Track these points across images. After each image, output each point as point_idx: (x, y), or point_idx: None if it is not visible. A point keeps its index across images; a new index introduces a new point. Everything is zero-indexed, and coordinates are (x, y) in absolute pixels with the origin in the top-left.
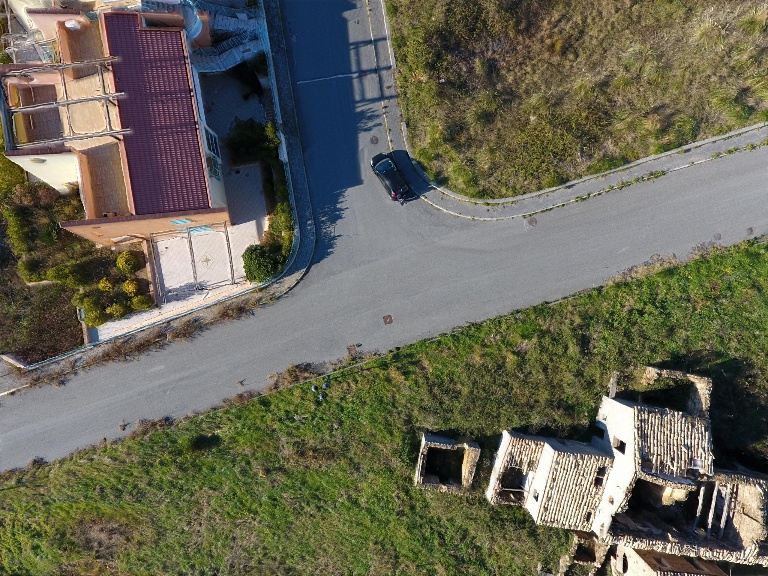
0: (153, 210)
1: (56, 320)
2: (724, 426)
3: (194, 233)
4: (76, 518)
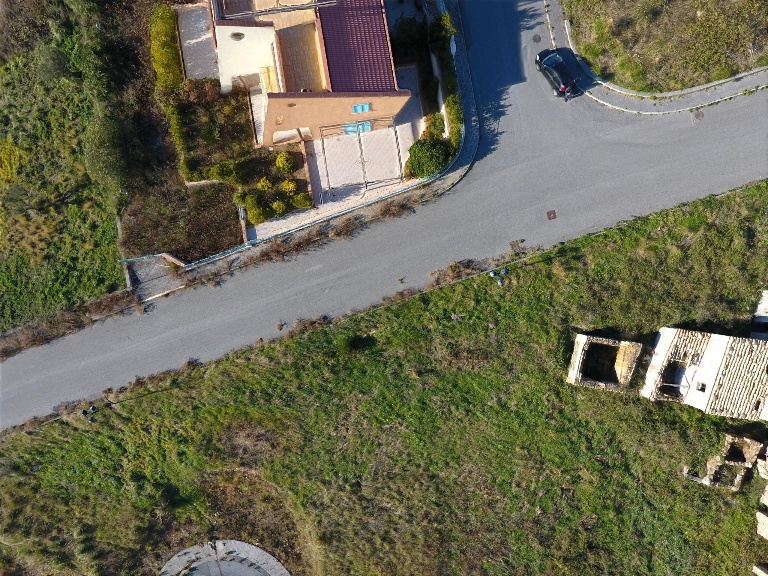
0: (347, 89)
1: (216, 219)
2: None
3: (350, 135)
4: (224, 423)
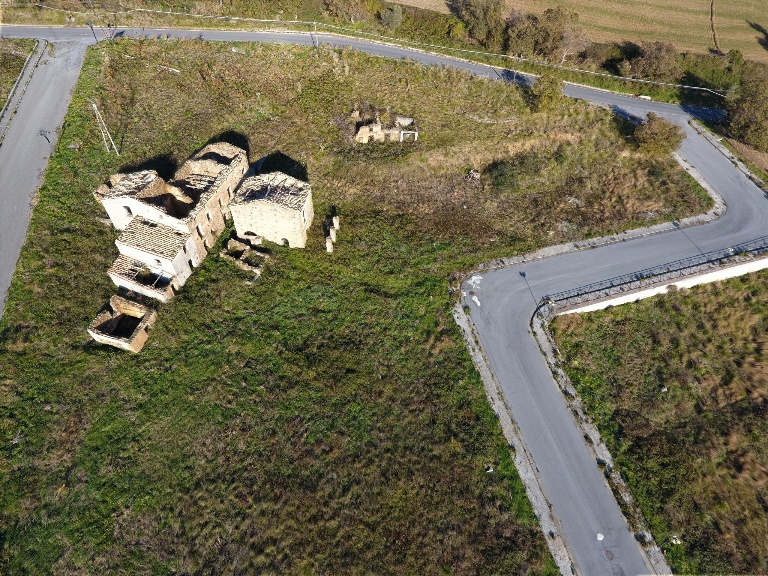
0: None
1: None
2: None
3: None
4: None
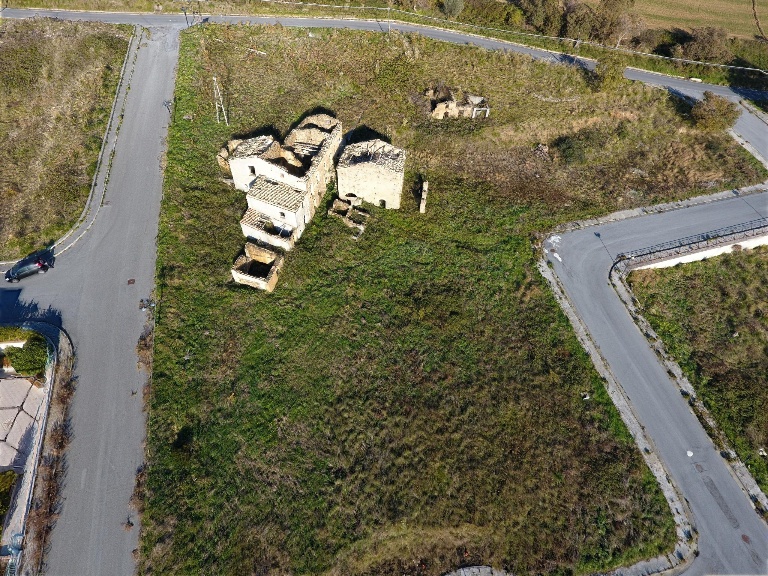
0: None
1: None
2: None
3: None
4: None
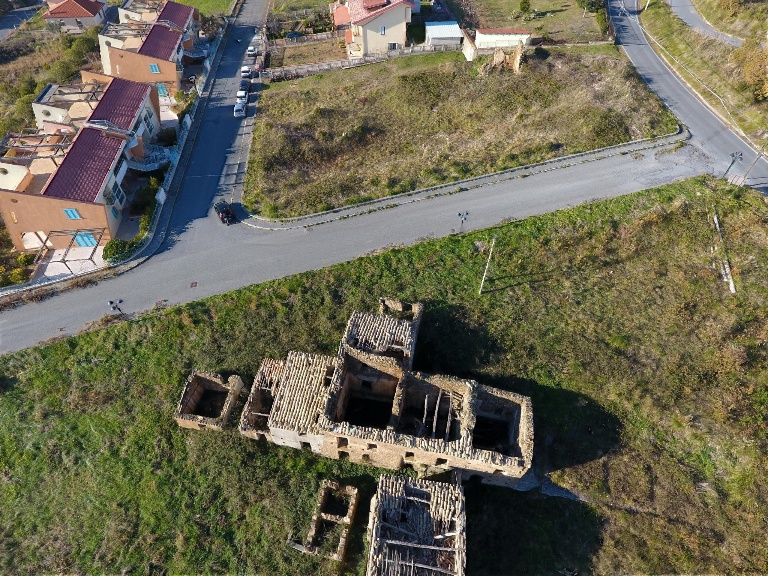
0: (55, 195)
1: None
2: (447, 352)
3: (84, 248)
4: None
